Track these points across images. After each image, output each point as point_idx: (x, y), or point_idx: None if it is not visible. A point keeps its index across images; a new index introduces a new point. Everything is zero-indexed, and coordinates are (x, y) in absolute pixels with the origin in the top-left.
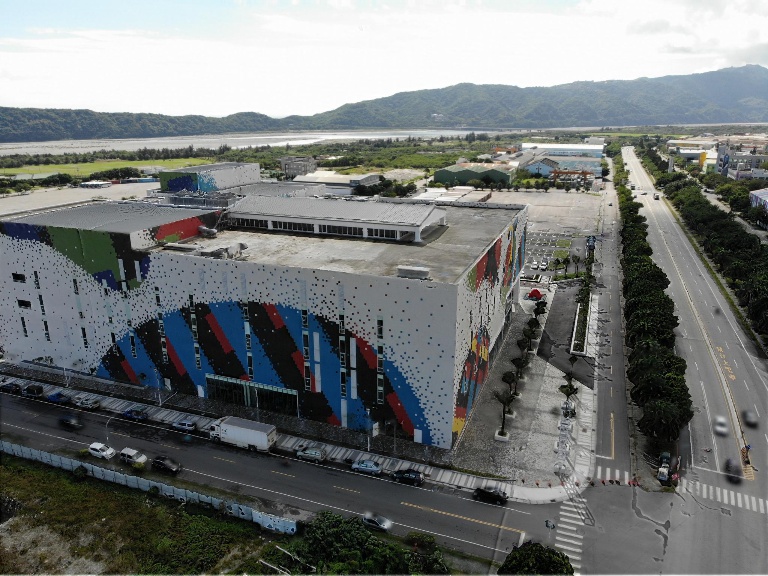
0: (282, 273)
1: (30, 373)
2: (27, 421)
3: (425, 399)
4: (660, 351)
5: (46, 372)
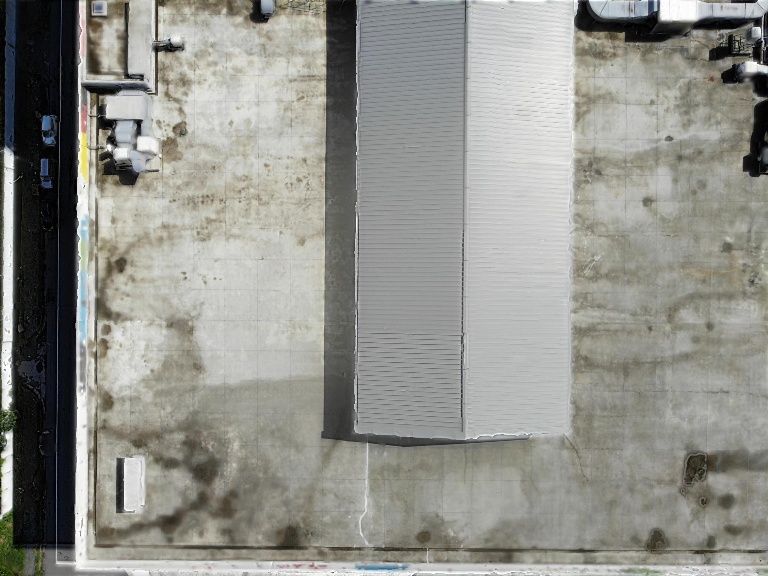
0: None
1: None
2: None
3: None
4: None
5: None
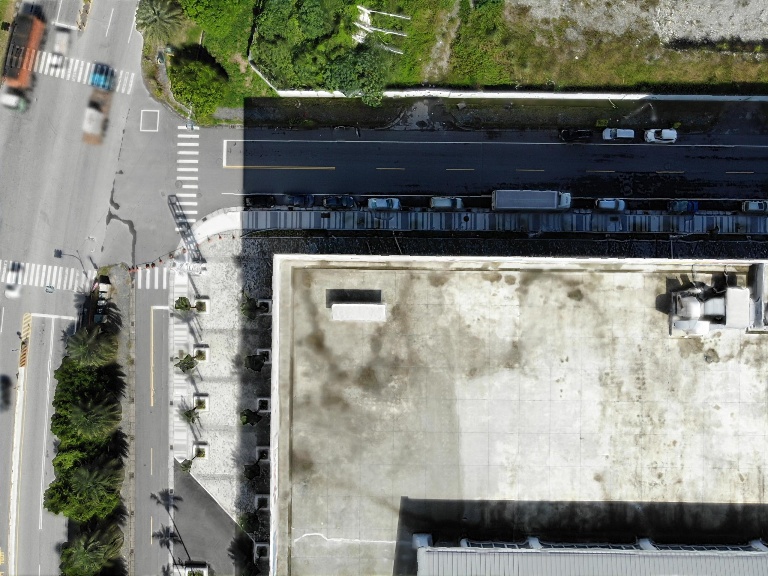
0: None
1: None
2: None
3: None
4: None
5: None
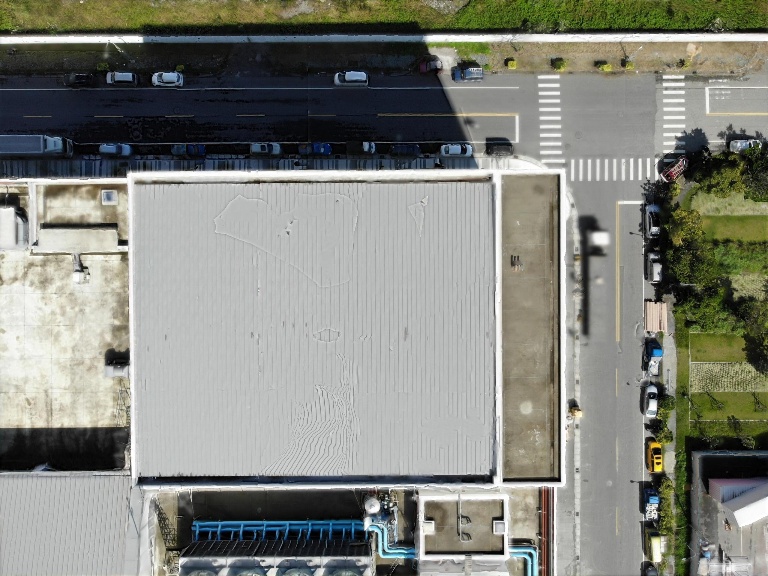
0: None
1: None
2: (309, 100)
3: None
4: None
5: None
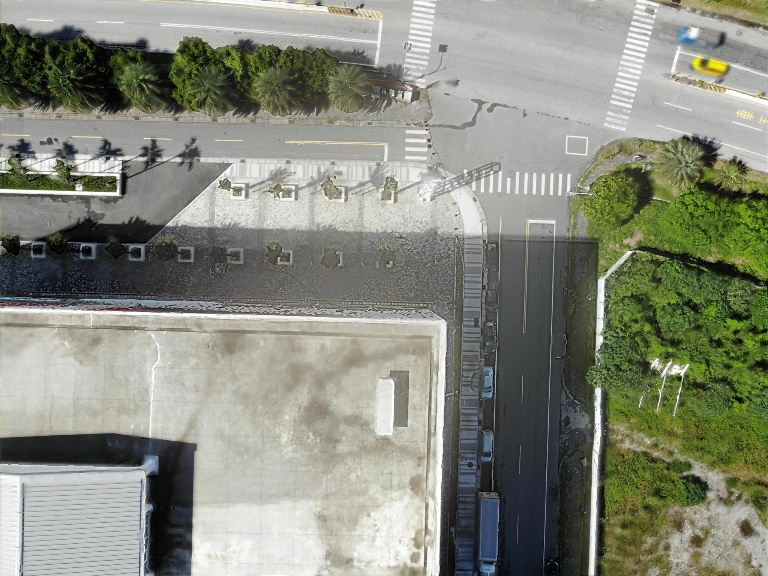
0: None
1: None
2: None
3: None
4: None
5: None
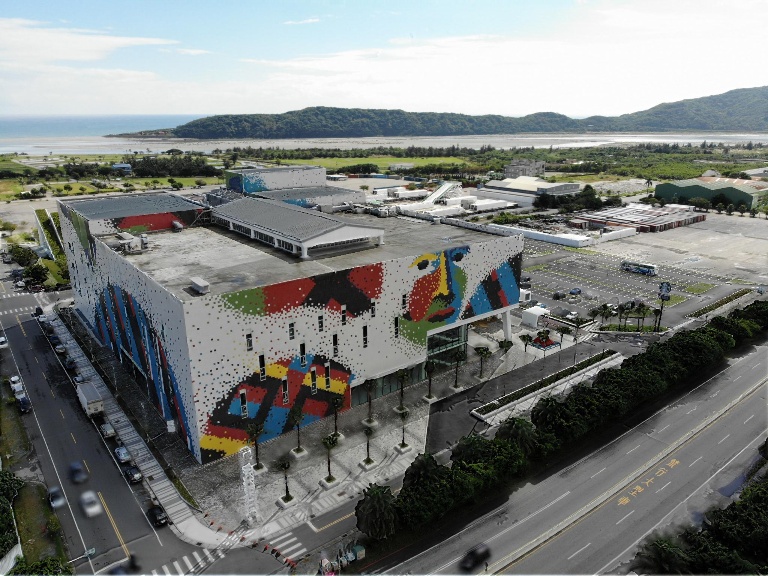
0: (129, 268)
1: (71, 318)
2: (21, 351)
3: (186, 409)
4: (537, 437)
5: (79, 320)
